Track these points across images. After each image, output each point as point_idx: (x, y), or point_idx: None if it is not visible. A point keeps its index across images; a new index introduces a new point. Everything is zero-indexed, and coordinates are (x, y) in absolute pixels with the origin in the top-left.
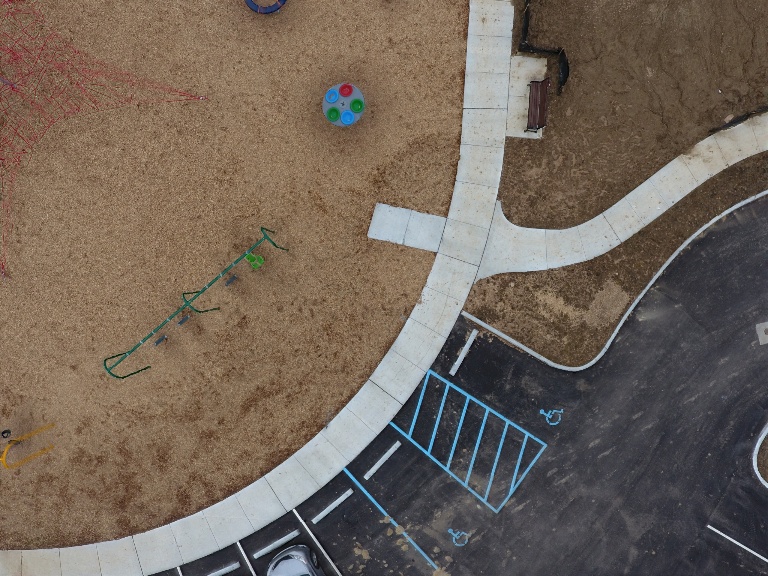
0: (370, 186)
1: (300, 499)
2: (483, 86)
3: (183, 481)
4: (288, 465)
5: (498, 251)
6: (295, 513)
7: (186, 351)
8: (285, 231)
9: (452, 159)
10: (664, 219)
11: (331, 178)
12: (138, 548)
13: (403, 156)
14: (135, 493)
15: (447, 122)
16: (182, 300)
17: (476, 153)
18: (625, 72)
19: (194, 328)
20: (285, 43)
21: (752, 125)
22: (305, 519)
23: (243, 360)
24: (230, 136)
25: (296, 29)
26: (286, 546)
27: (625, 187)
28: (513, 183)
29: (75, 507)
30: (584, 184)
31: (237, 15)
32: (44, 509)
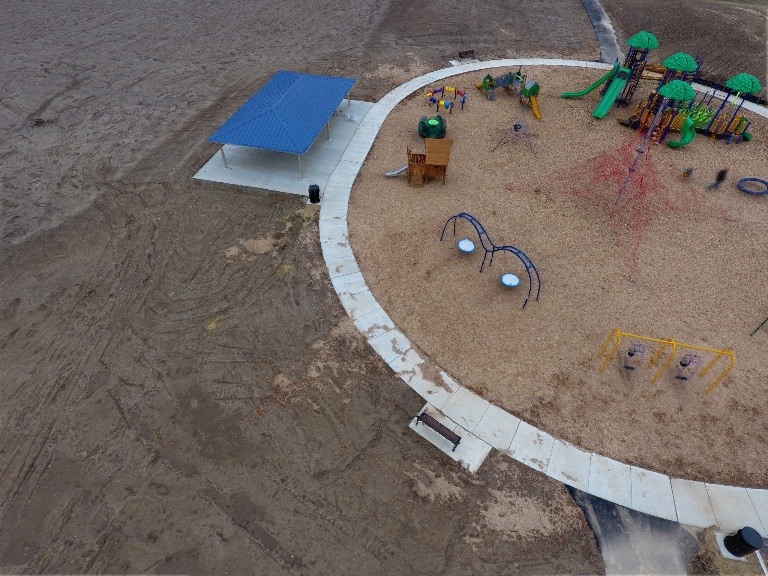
0: None
1: None
2: None
3: None
4: None
5: None
6: None
7: None
8: None
9: None
10: None
11: None
12: None
13: None
14: None
15: None
16: None
17: None
18: None
19: None
20: None
21: None
22: None
23: None
24: (762, 238)
25: None
26: None
27: None
28: None
29: (748, 449)
30: None
31: (738, 195)
32: (716, 445)
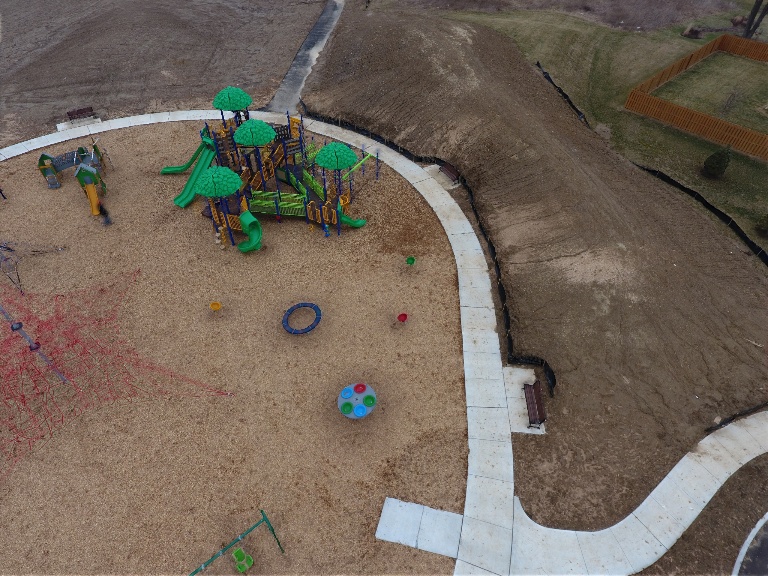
0: (379, 479)
1: None
2: (482, 389)
3: None
4: None
5: (527, 558)
6: None
7: None
8: (283, 528)
9: (462, 452)
10: (703, 521)
11: (340, 469)
12: None
13: (413, 449)
14: None
15: (453, 418)
16: None
17: (485, 447)
18: (605, 379)
19: None
20: (311, 355)
21: (743, 426)
22: None
23: None
24: (247, 427)
25: (321, 345)
26: None
27: (646, 484)
28: (528, 478)
29: None
30: (602, 480)
31: (275, 335)
32: None
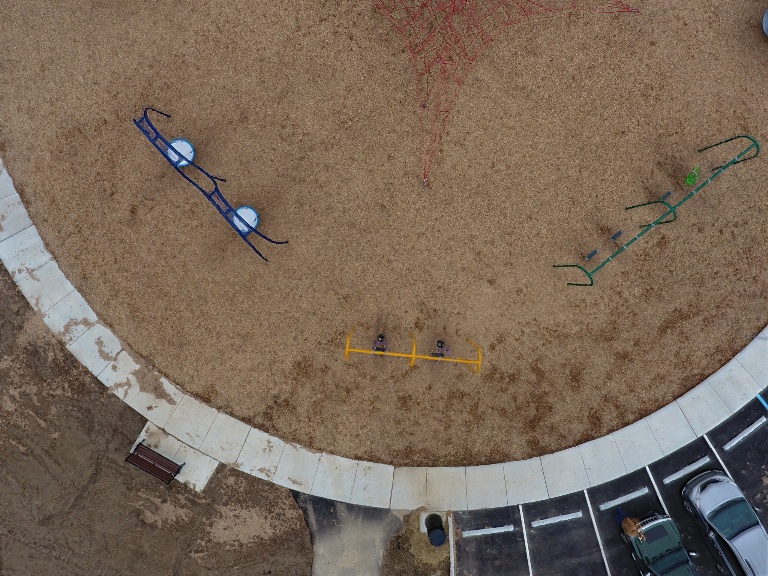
0: None
1: (711, 425)
2: None
3: (595, 402)
4: (701, 390)
5: None
6: (706, 439)
7: (605, 269)
8: (709, 150)
9: None
10: None
11: (757, 98)
12: (545, 469)
13: None
14: (545, 413)
15: None
16: (602, 217)
17: None
18: None
19: (612, 246)
20: None
21: None
22: (715, 445)
23: (661, 281)
24: (660, 51)
25: None
26: (699, 471)
27: None
28: None
29: (485, 425)
30: None
31: None
32: (453, 426)
